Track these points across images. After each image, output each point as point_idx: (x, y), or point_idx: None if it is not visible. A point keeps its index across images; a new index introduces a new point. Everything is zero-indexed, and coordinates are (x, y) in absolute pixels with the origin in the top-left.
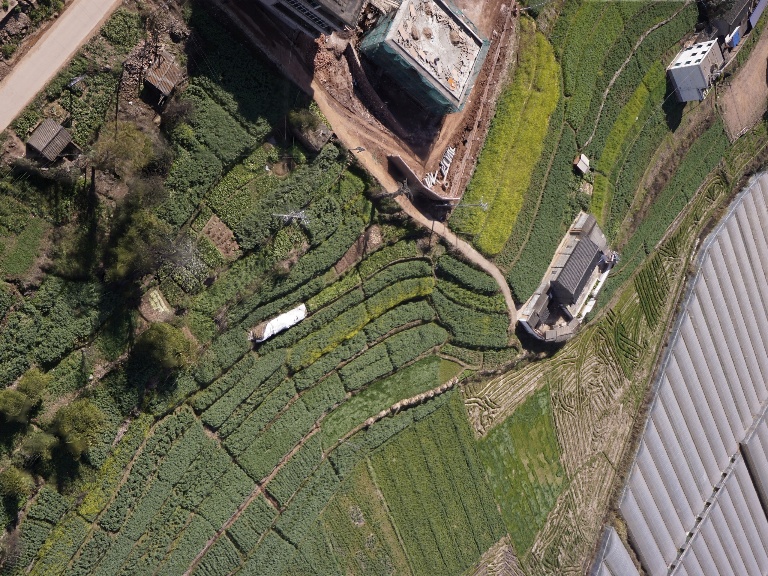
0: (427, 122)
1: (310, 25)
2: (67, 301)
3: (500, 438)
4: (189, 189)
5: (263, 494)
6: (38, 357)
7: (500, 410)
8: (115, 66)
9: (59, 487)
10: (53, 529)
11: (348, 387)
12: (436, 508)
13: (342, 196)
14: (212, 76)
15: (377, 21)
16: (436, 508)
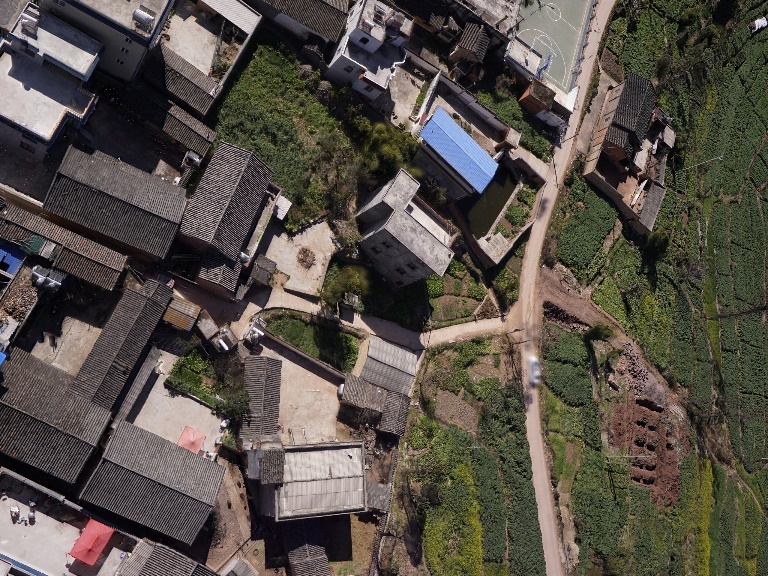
0: None
1: None
2: None
3: None
4: None
5: None
6: (686, 5)
7: None
8: None
9: None
10: None
11: None
12: None
13: None
14: None
15: None
16: None
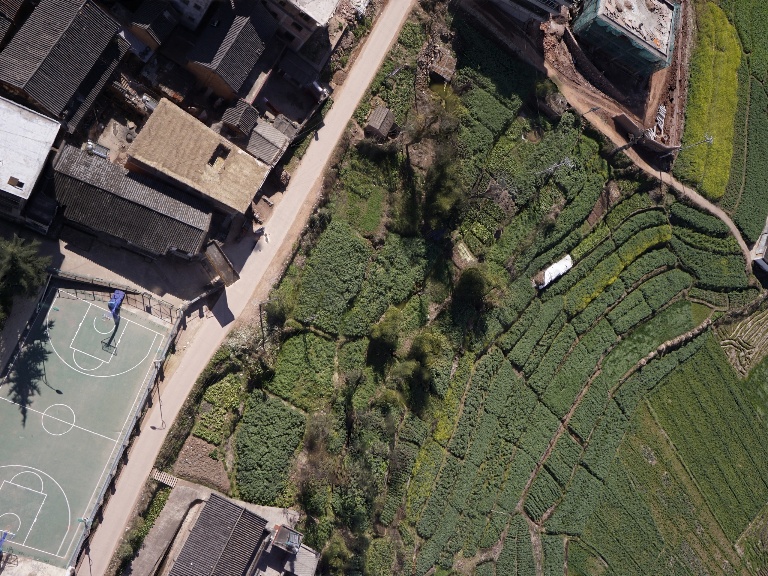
0: (637, 87)
1: (542, 9)
2: (404, 253)
3: (762, 378)
4: (472, 157)
5: (567, 431)
6: (392, 299)
7: (755, 351)
8: (411, 64)
9: (418, 414)
10: (419, 452)
11: (617, 330)
12: (718, 447)
13: (583, 156)
14: (473, 66)
15: (583, 7)
16: (718, 447)
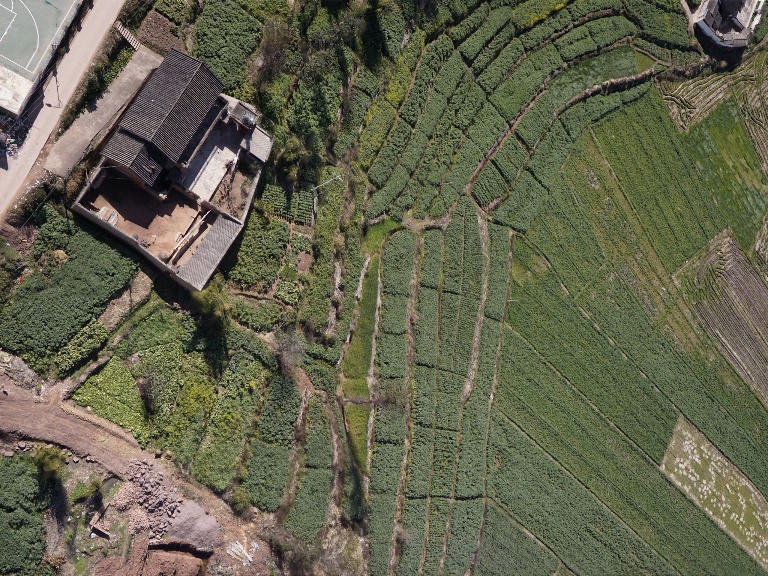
0: None
1: None
2: None
3: (701, 136)
4: None
5: (514, 135)
6: None
7: (696, 111)
8: None
9: (370, 70)
10: (371, 105)
11: (564, 56)
12: (658, 188)
13: None
14: None
15: None
16: (658, 188)
